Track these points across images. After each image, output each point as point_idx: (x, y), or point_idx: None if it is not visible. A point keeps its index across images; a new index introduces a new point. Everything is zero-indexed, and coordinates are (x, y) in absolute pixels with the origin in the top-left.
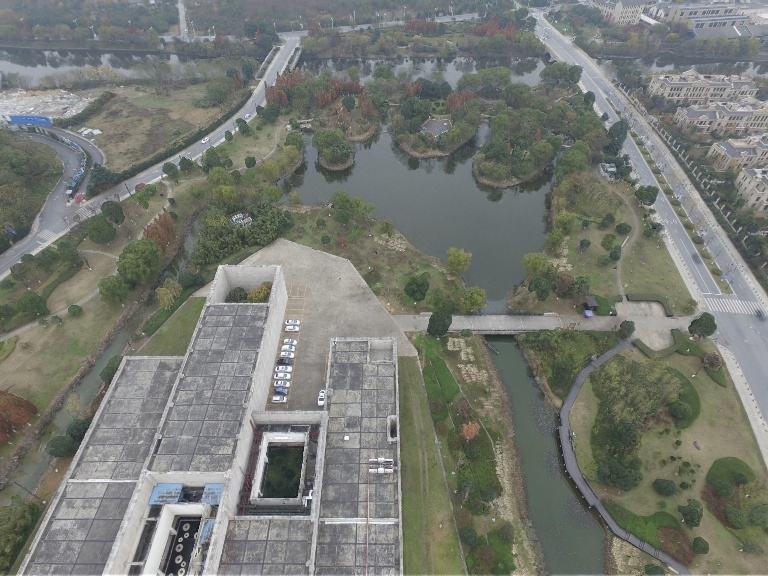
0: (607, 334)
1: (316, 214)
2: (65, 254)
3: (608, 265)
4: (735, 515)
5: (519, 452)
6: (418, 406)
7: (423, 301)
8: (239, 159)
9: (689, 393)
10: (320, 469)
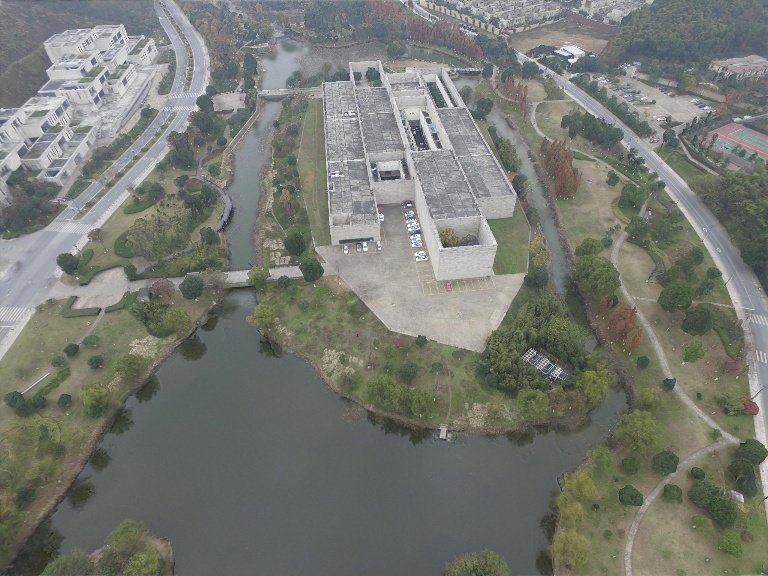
0: (150, 273)
1: (455, 403)
2: (673, 266)
3: (87, 347)
4: (158, 184)
5: (257, 212)
6: (317, 220)
7: (307, 291)
8: (679, 541)
9: (123, 238)
10: (368, 165)
